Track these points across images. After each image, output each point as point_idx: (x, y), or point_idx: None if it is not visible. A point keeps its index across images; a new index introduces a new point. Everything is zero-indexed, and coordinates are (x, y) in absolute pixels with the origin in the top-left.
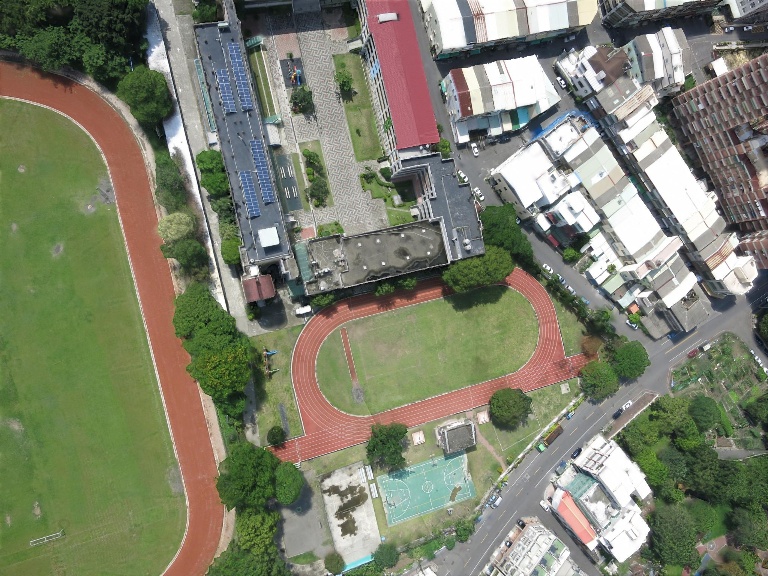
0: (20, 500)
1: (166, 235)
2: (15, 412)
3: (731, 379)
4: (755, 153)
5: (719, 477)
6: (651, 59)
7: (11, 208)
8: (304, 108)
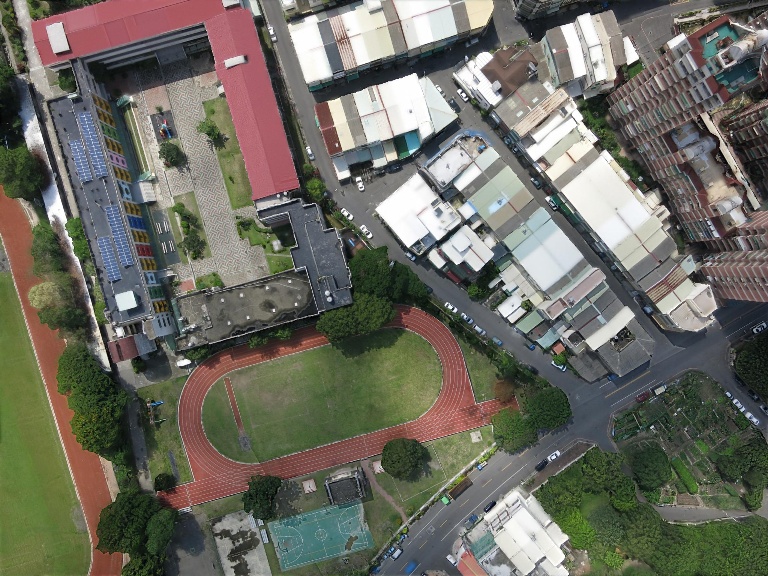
0: None
1: None
2: None
3: (698, 426)
4: (704, 159)
5: (660, 546)
6: (566, 56)
7: None
8: (175, 161)
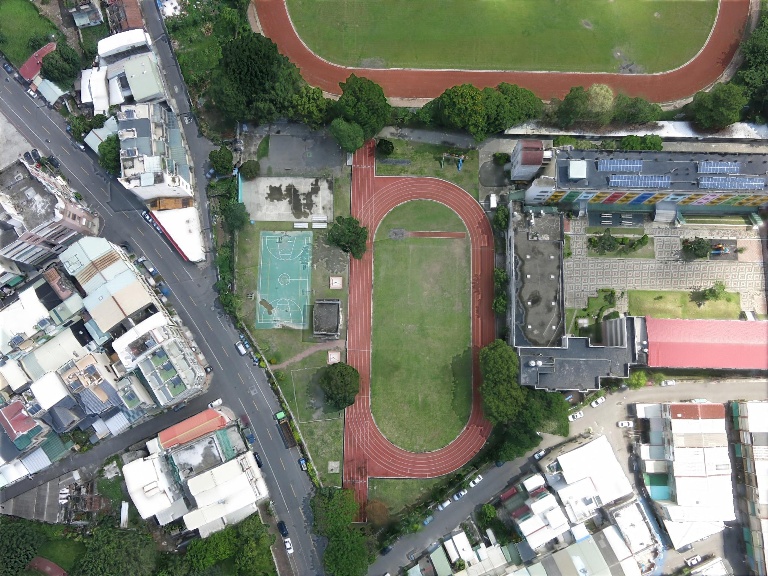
0: None
1: None
2: None
3: None
4: None
5: None
6: None
7: (626, 1)
8: (688, 251)
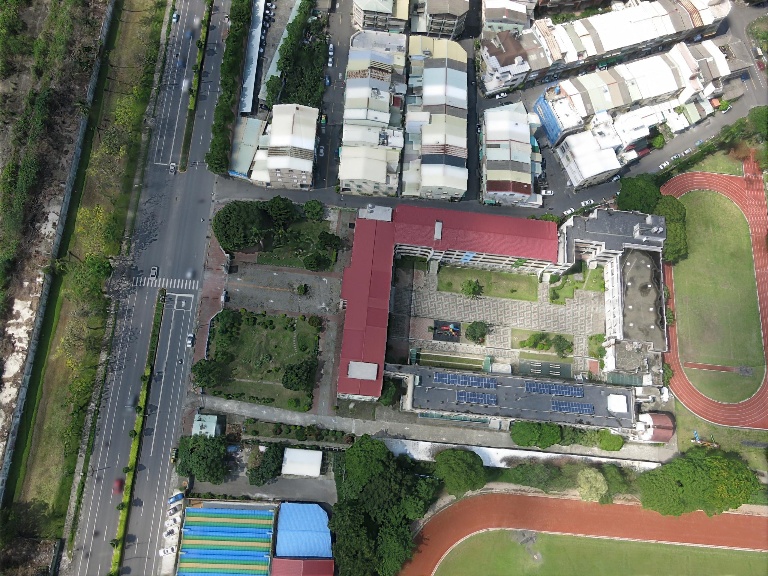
0: None
1: (599, 495)
2: None
3: None
4: None
5: None
6: (510, 11)
7: None
8: None
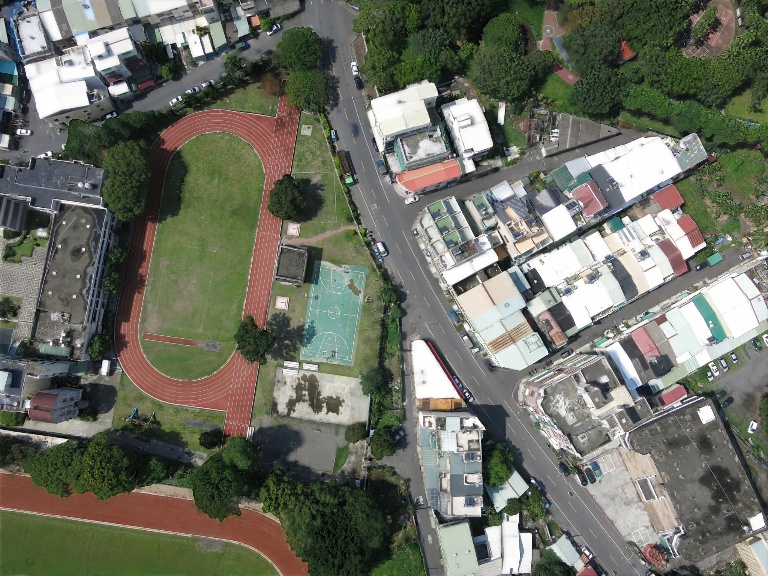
0: None
1: None
2: None
3: None
4: None
5: None
6: None
7: None
8: None
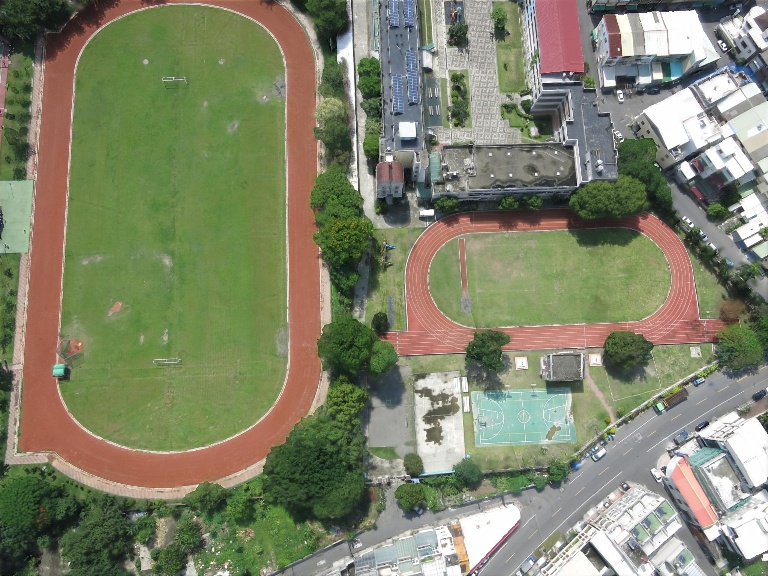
0: (155, 324)
1: (321, 115)
2: (170, 250)
3: None
4: None
5: None
6: None
7: (207, 89)
8: (459, 41)
